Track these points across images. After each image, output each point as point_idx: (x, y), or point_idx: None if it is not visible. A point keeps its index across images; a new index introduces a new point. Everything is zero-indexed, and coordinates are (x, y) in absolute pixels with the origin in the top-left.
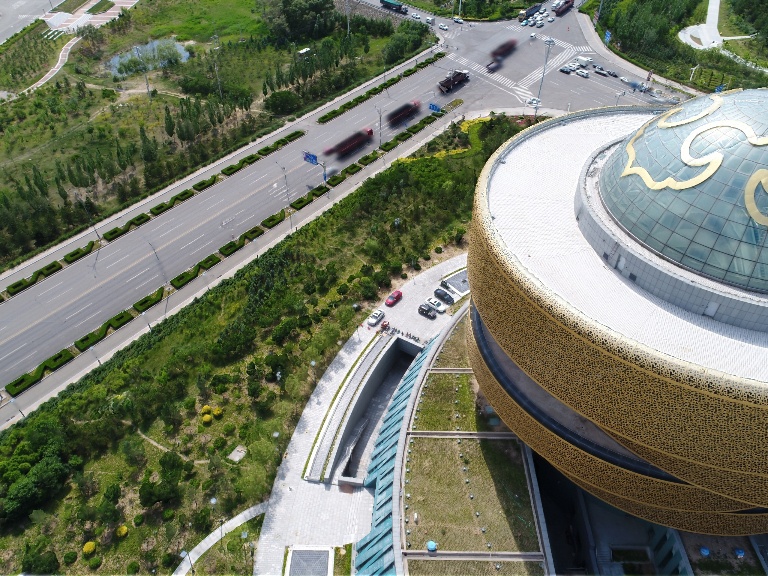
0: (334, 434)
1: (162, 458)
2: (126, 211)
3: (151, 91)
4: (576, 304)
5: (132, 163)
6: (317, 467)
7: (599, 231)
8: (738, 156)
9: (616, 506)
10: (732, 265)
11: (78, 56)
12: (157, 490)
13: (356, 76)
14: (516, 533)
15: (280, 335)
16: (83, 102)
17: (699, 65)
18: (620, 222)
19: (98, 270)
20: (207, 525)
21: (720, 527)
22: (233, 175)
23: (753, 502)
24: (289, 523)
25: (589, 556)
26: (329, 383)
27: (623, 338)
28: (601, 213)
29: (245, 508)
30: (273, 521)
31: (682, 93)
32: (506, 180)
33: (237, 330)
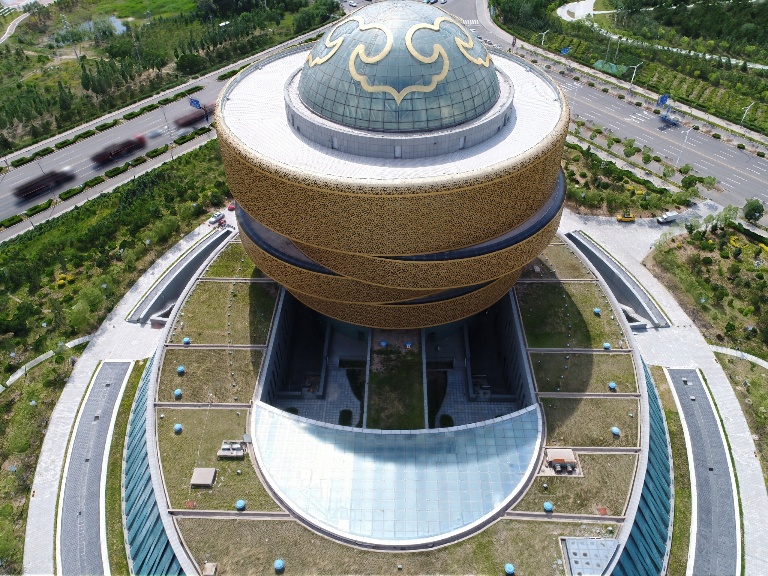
0: (157, 292)
1: (18, 306)
2: (35, 146)
3: (80, 56)
4: (251, 143)
5: (48, 110)
6: (138, 313)
7: (285, 101)
8: (351, 38)
9: (322, 312)
10: (345, 111)
11: (24, 29)
12: (6, 322)
13: (262, 44)
14: (253, 335)
15: (134, 228)
16: (19, 65)
17: (564, 34)
18: (299, 94)
19: (1, 187)
20: (44, 348)
21: (385, 320)
22: (132, 119)
23: (377, 283)
24: (106, 347)
25: (322, 363)
26: (165, 261)
27: (262, 156)
28: (293, 91)
29: (76, 338)
30: (94, 345)
31: (542, 57)
32: (254, 79)
33: (103, 227)
